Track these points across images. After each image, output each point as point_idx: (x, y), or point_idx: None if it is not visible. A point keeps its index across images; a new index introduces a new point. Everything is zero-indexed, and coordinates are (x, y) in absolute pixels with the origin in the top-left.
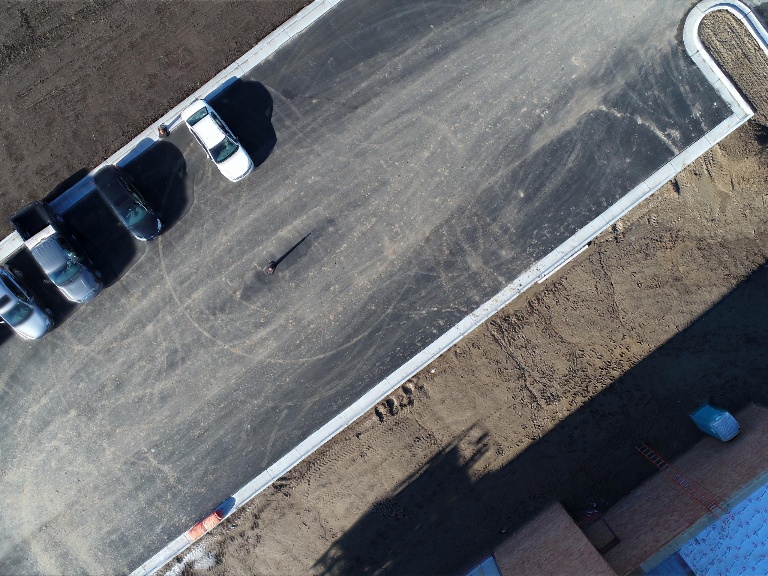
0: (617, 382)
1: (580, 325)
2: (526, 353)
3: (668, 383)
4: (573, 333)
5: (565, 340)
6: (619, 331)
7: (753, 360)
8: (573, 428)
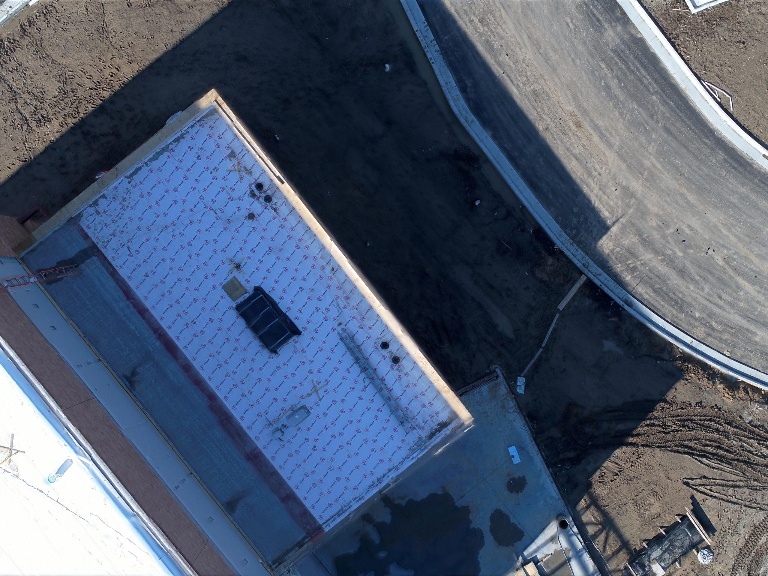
0: (107, 102)
1: (69, 45)
2: (17, 75)
3: (157, 102)
4: (63, 54)
5: (55, 61)
6: (108, 51)
7: (244, 78)
8: (65, 150)
